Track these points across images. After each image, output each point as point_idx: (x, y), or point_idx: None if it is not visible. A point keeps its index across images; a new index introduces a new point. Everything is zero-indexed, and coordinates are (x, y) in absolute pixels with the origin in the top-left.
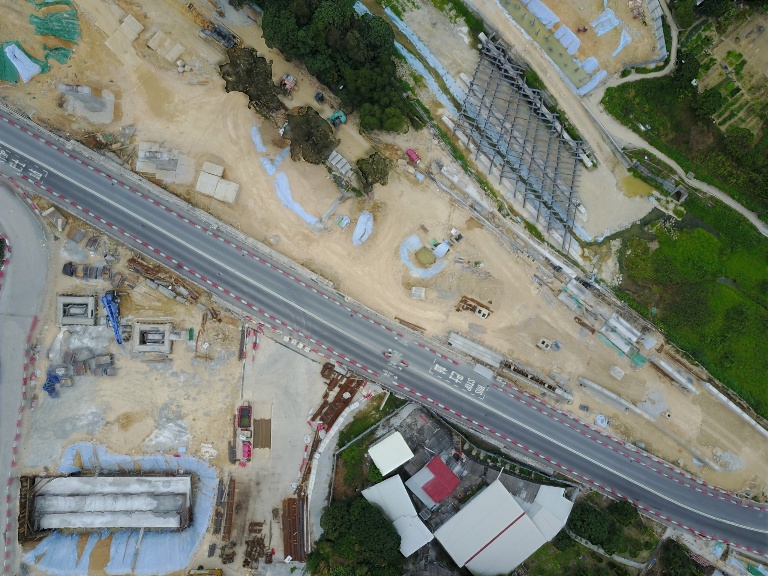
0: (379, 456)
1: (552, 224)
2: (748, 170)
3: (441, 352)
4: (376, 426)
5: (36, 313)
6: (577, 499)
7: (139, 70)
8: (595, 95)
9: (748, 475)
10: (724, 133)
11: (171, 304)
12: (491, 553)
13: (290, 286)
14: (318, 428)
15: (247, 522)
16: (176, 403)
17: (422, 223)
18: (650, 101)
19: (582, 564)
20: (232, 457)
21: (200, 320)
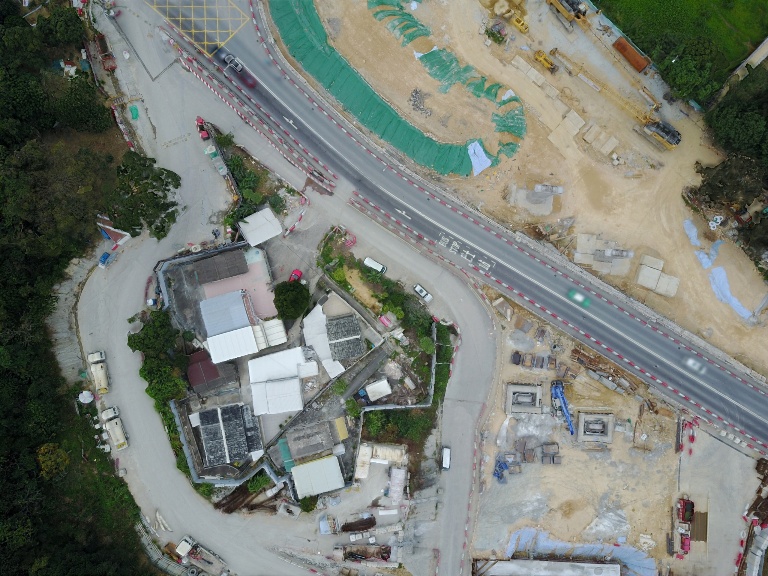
0: None
1: None
2: None
3: None
4: None
5: (484, 400)
6: None
7: (580, 164)
8: None
9: None
10: None
11: (609, 394)
12: None
13: (725, 380)
14: (753, 524)
15: None
16: (616, 493)
17: None
18: None
19: None
20: (671, 549)
21: (637, 411)
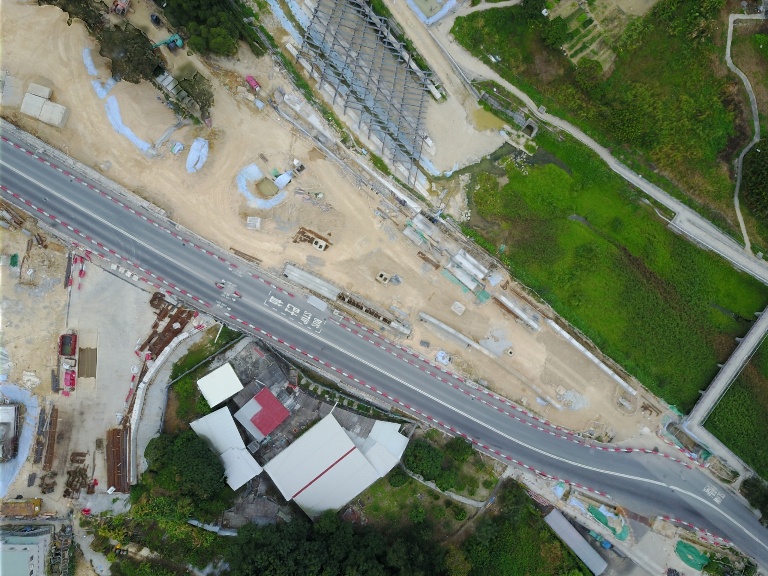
0: (208, 387)
1: (398, 157)
2: (598, 104)
3: (277, 284)
4: (211, 359)
5: None
6: (416, 436)
7: None
8: (444, 24)
9: (592, 415)
10: (576, 66)
11: None
12: (320, 487)
13: (120, 213)
14: (146, 358)
15: (69, 452)
16: None
17: (261, 152)
18: (501, 32)
19: (419, 501)
20: (55, 386)
21: (25, 246)
